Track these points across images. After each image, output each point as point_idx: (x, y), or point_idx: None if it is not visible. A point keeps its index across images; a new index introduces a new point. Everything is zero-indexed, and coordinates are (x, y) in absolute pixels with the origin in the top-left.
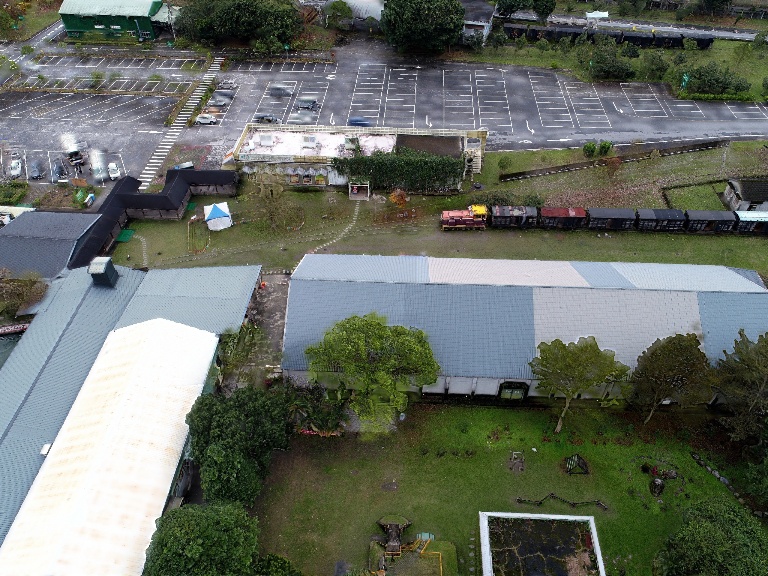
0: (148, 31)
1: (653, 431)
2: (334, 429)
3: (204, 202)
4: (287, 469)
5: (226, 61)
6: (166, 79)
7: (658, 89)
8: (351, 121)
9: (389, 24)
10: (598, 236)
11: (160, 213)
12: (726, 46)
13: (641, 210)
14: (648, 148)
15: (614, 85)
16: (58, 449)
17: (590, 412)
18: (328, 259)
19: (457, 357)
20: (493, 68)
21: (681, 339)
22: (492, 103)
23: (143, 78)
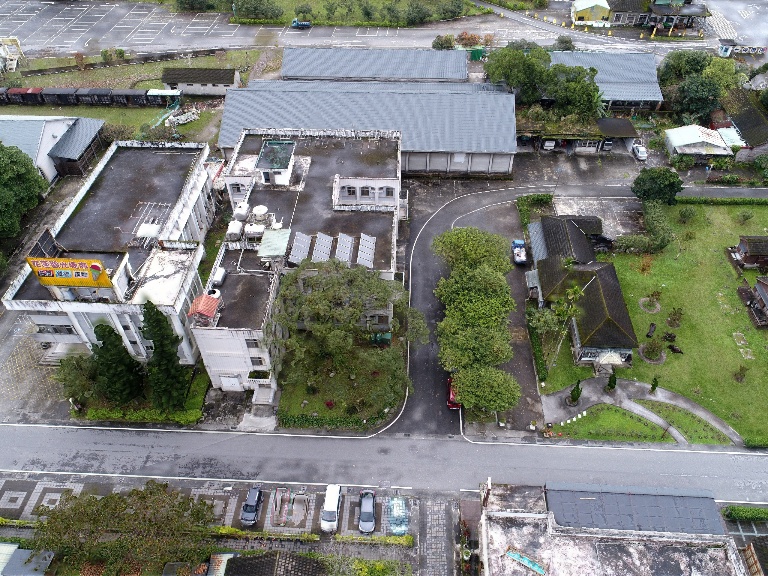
0: None
1: None
2: None
3: None
4: None
5: None
6: None
7: (223, 17)
8: None
9: None
10: (52, 109)
11: None
12: None
13: (82, 89)
14: None
15: (192, 14)
16: None
17: None
18: None
19: None
20: (111, 3)
21: None
22: (79, 27)
23: None
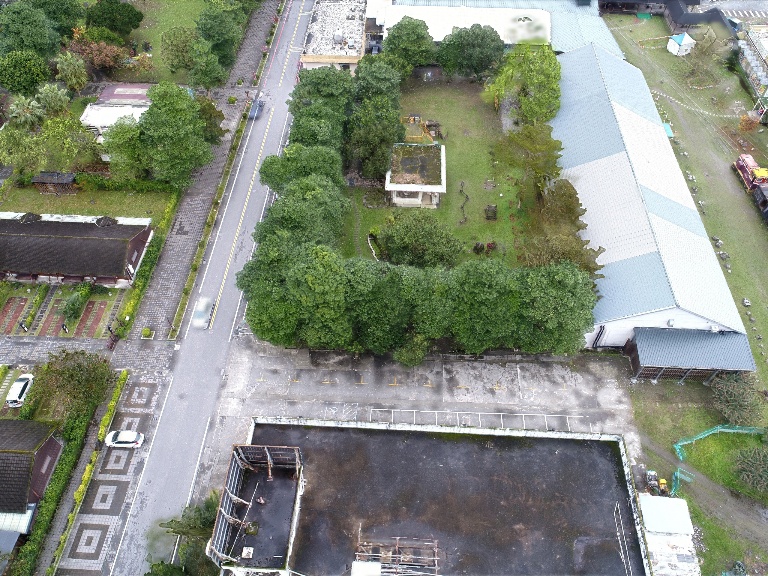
0: None
1: None
2: (487, 85)
3: None
4: (472, 95)
5: None
6: None
7: None
8: None
9: None
10: None
11: (672, 21)
12: None
13: None
14: None
15: None
16: (462, 7)
17: None
18: (636, 76)
19: (555, 132)
20: None
21: (566, 183)
22: None
23: None
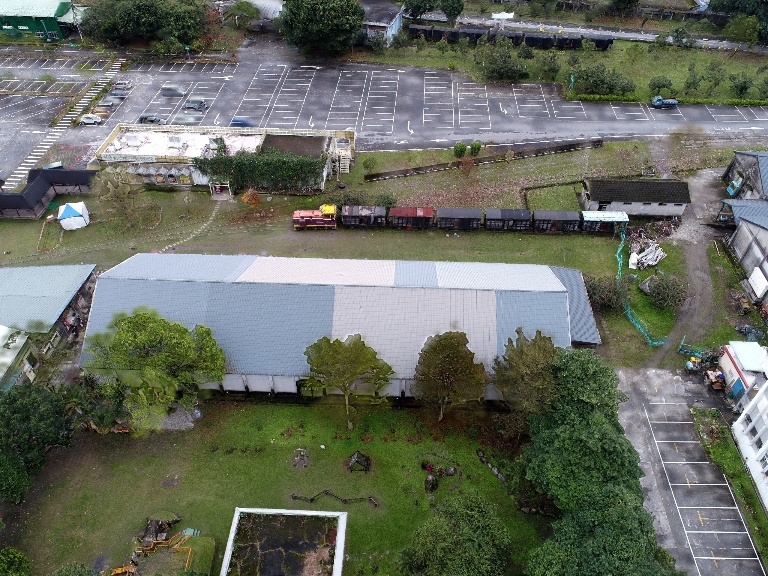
0: (56, 32)
1: (446, 428)
2: (110, 426)
3: (67, 202)
4: (74, 466)
5: (128, 62)
6: (64, 79)
7: (548, 90)
8: (235, 121)
9: (286, 25)
10: (446, 236)
11: (18, 212)
12: (628, 47)
13: (489, 210)
14: (521, 148)
15: (506, 86)
16: None
17: (389, 410)
18: (156, 258)
19: (253, 355)
20: (391, 69)
21: (443, 337)
22: (380, 104)
23: (41, 78)
